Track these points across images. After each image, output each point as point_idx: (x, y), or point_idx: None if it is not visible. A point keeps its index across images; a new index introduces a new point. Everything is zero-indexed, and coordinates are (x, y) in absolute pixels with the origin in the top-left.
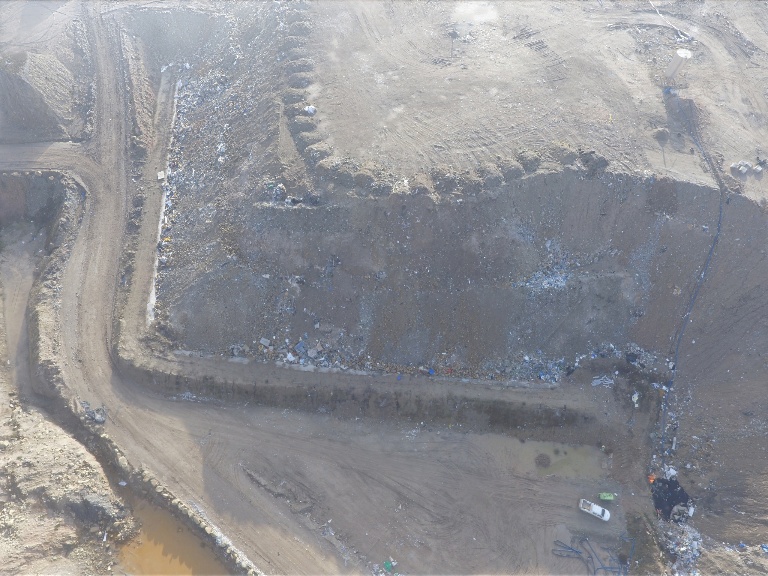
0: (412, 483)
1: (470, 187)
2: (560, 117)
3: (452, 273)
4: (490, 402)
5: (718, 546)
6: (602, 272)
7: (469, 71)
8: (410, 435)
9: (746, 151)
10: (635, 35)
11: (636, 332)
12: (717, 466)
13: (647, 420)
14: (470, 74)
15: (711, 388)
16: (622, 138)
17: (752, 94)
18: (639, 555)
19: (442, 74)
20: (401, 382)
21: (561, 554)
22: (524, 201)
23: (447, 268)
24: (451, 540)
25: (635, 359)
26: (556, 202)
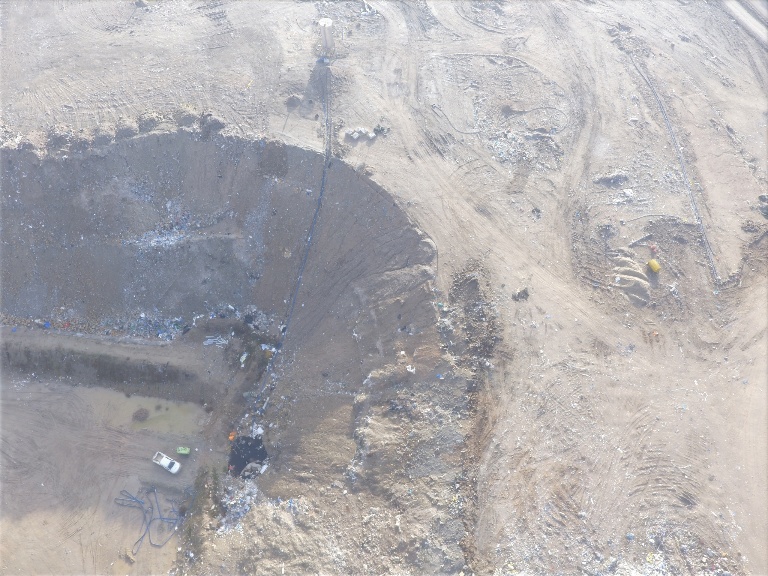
0: (2, 429)
1: (76, 144)
2: (200, 82)
3: (66, 229)
4: (96, 356)
5: (264, 501)
6: (218, 233)
7: (135, 38)
8: (19, 385)
9: (370, 118)
10: (320, 8)
11: (255, 294)
12: (289, 425)
13: (243, 379)
14: (135, 40)
15: (309, 350)
16: (252, 103)
17: (407, 65)
18: (195, 507)
19: (107, 40)
20: (15, 333)
21: (123, 503)
22: (138, 161)
23: (61, 224)
24: (19, 484)
25: (252, 321)
26: (173, 163)
